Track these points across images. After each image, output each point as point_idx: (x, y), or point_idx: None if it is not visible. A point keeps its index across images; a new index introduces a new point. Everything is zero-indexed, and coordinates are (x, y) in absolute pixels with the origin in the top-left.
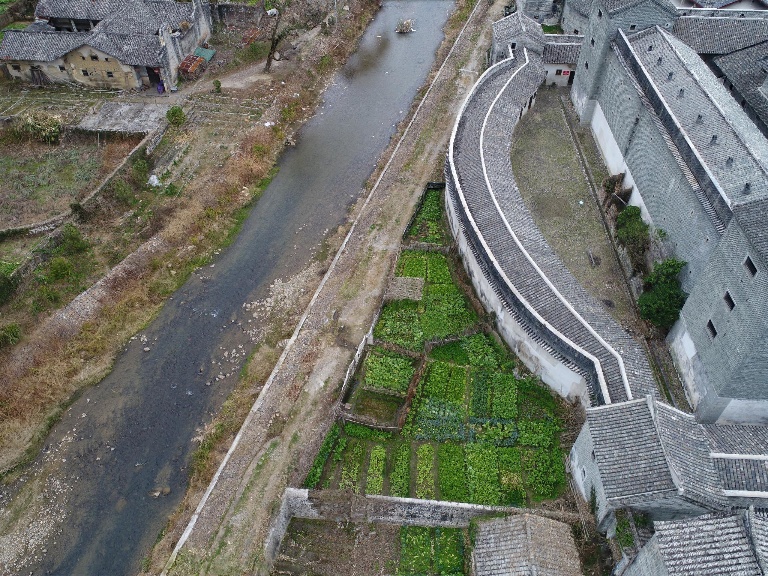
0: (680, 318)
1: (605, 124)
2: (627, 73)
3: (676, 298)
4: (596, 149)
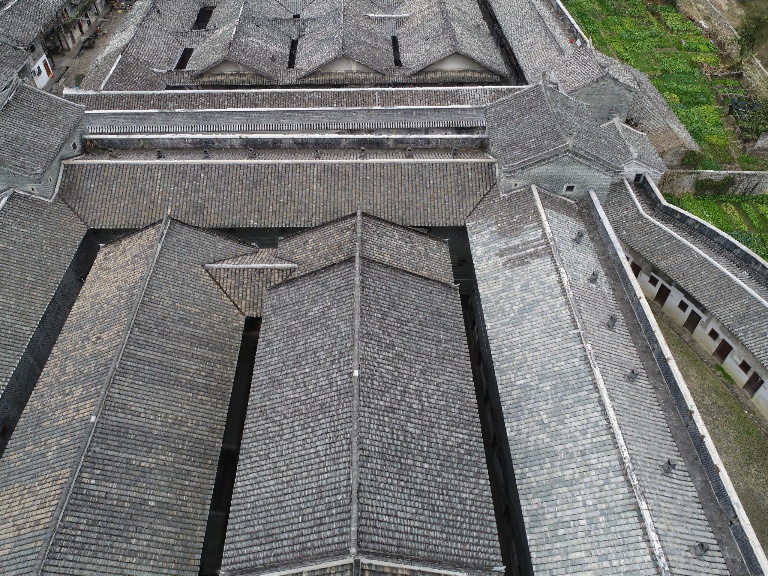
0: None
1: None
2: None
3: None
4: None
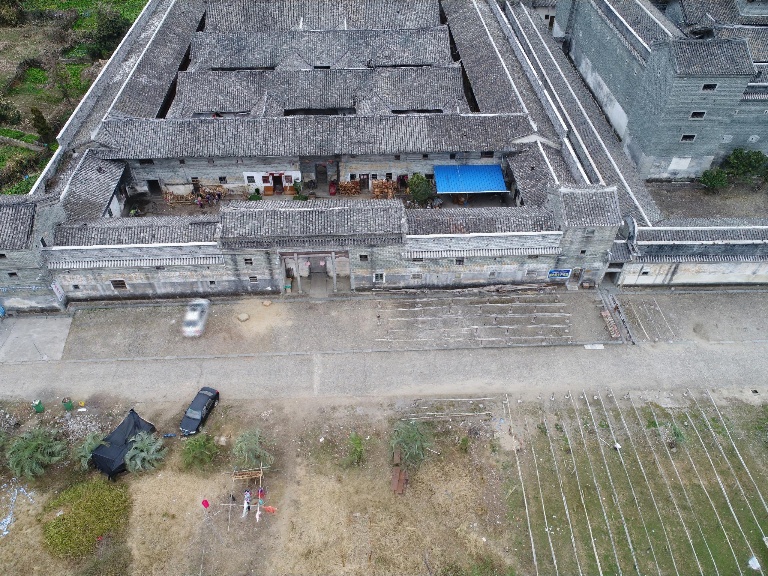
0: None
1: None
2: None
3: None
4: None
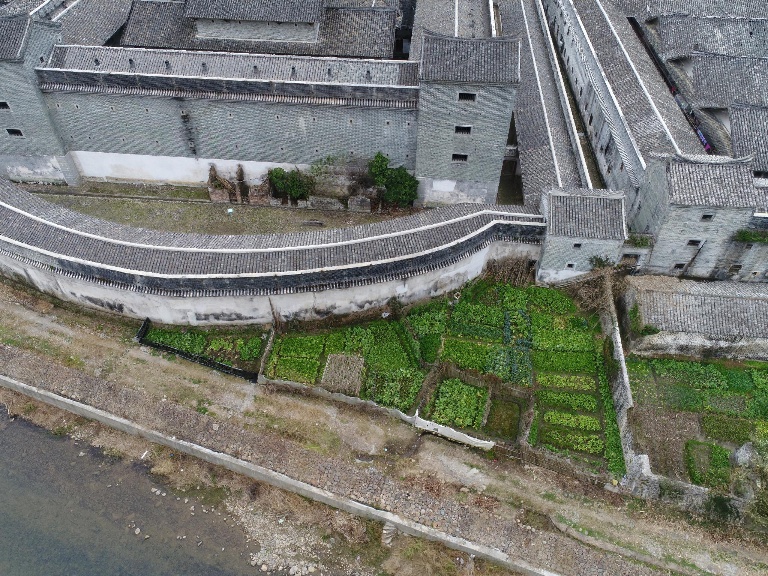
0: (419, 181)
1: (119, 157)
2: (121, 92)
3: (407, 173)
4: (129, 185)
